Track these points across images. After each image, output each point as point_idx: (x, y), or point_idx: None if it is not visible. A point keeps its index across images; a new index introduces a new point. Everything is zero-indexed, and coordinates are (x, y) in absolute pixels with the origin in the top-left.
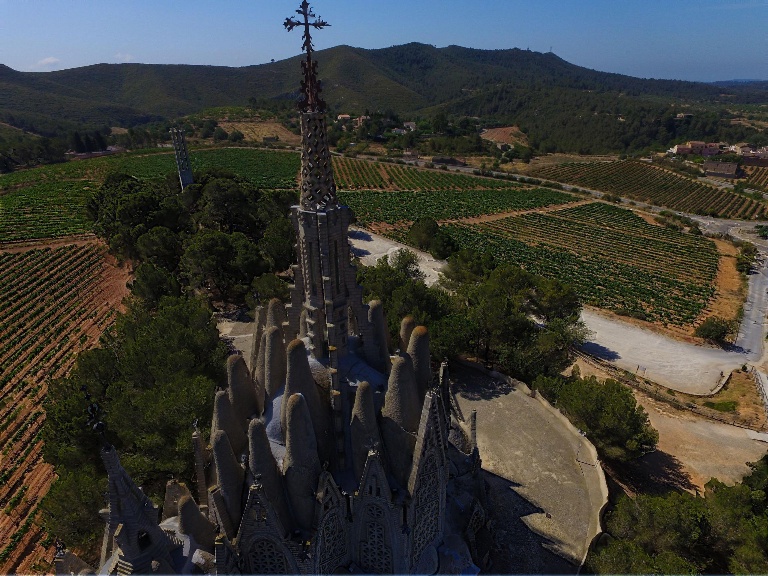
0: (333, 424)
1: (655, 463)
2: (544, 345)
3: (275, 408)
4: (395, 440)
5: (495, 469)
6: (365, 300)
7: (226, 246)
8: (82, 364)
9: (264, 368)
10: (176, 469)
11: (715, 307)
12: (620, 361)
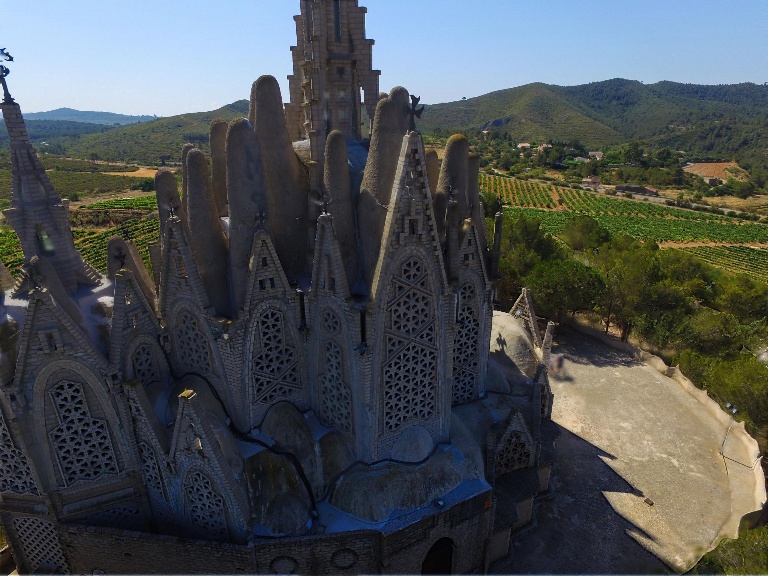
0: (308, 211)
1: None
2: (704, 326)
3: None
4: (368, 221)
5: (583, 432)
6: None
7: None
8: None
9: None
10: None
11: None
12: None
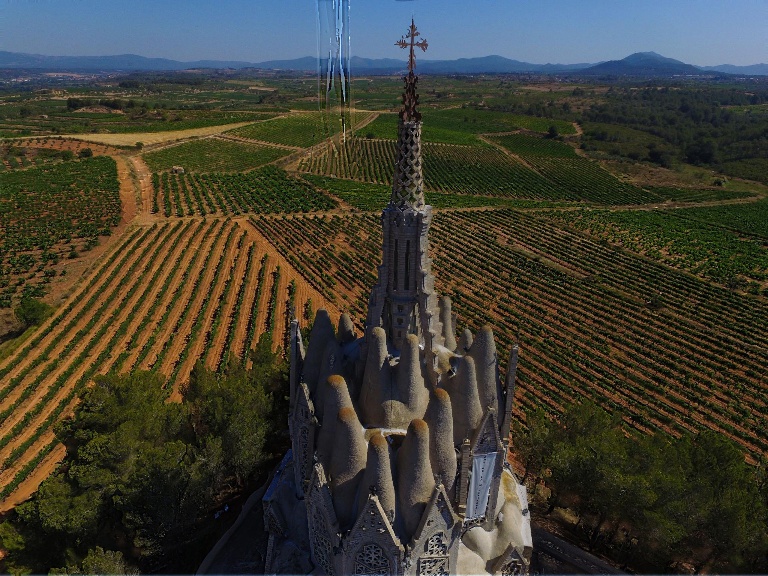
0: None
1: None
2: None
3: None
4: None
5: None
6: None
7: None
8: None
9: None
10: None
11: None
12: None
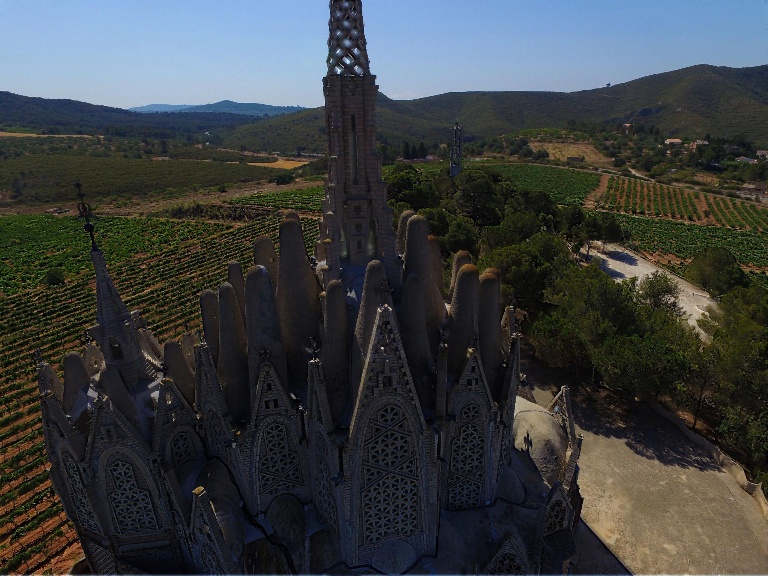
0: None
1: None
2: None
3: None
4: (355, 365)
5: (616, 546)
6: (552, 298)
7: (443, 223)
8: None
9: None
10: None
11: None
12: None
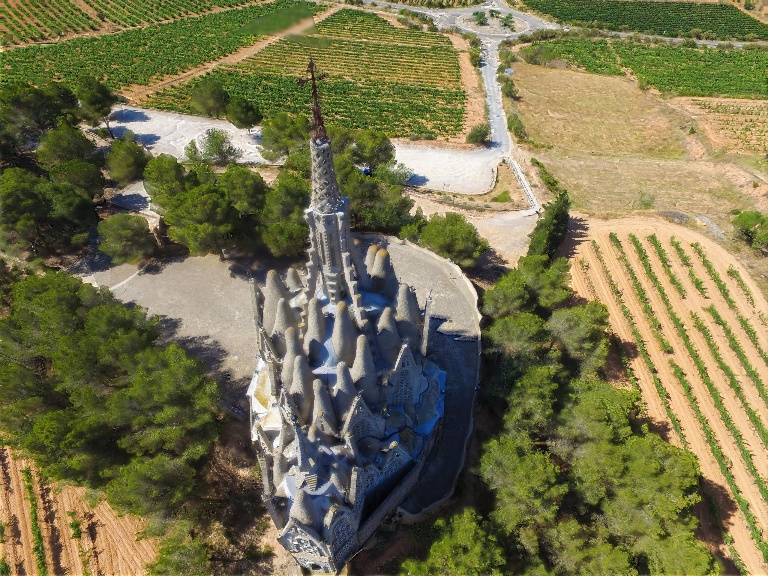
0: None
1: (482, 256)
2: (393, 199)
3: (329, 348)
4: (408, 331)
5: None
6: None
7: (28, 196)
8: (1, 390)
9: (286, 324)
10: (205, 421)
11: (470, 109)
12: (429, 183)
